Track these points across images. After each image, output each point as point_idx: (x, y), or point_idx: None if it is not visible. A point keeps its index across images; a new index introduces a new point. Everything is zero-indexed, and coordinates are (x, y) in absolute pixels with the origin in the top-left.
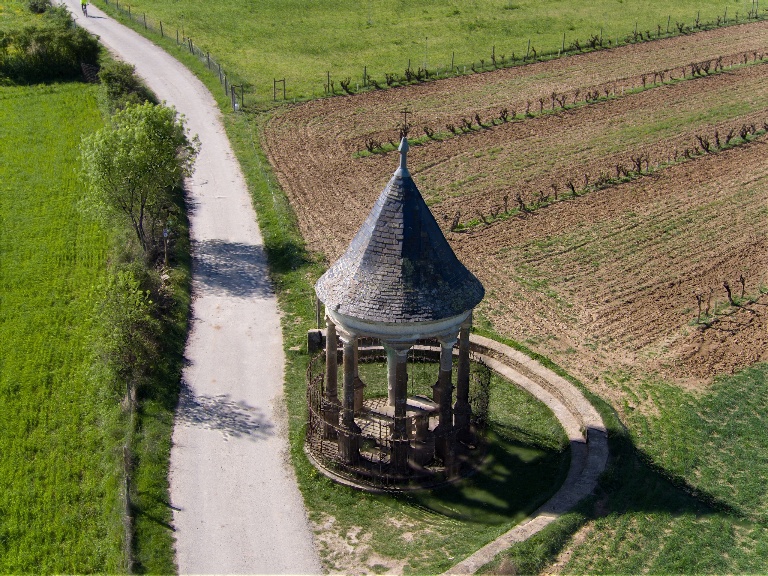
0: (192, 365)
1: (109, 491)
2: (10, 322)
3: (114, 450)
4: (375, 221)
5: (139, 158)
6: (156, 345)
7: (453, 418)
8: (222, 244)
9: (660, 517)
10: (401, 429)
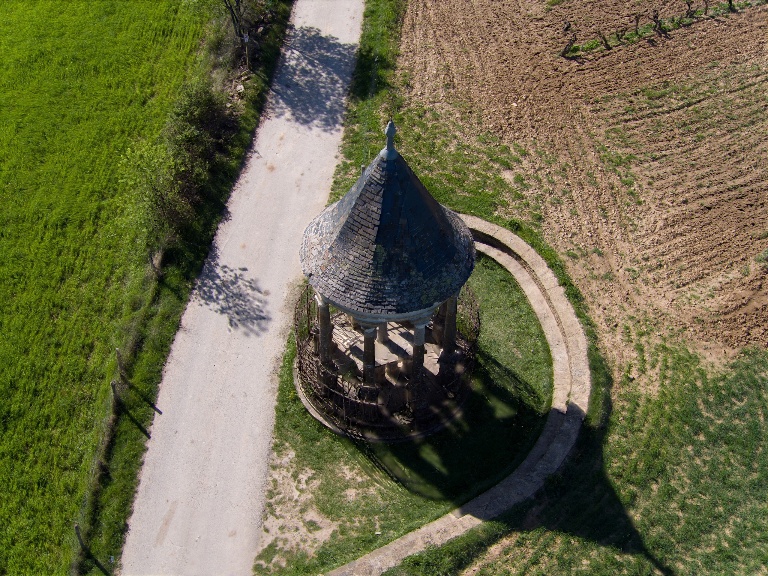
0: (230, 220)
1: (108, 376)
2: (84, 125)
3: (124, 327)
4: (356, 197)
5: None
6: (195, 199)
7: None
8: (317, 37)
9: (585, 543)
10: None
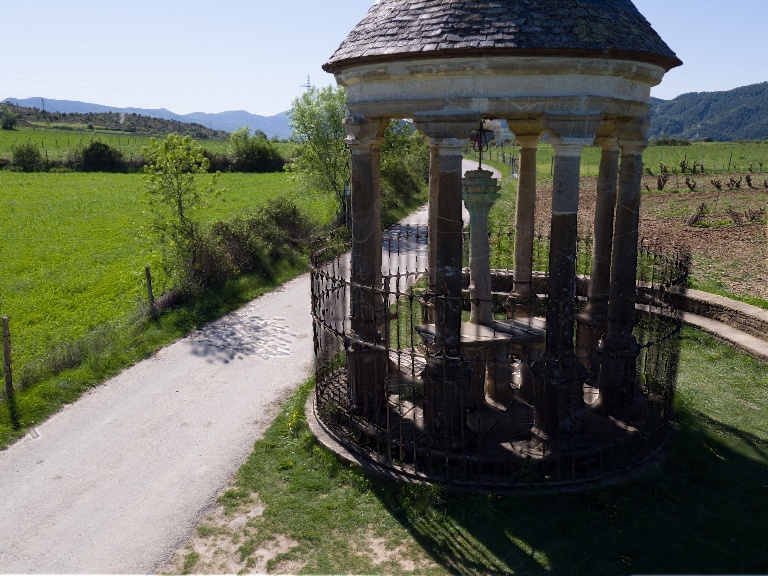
0: (282, 291)
1: None
2: None
3: None
4: None
5: (330, 111)
6: (241, 259)
7: None
8: (423, 226)
9: None
10: (445, 339)
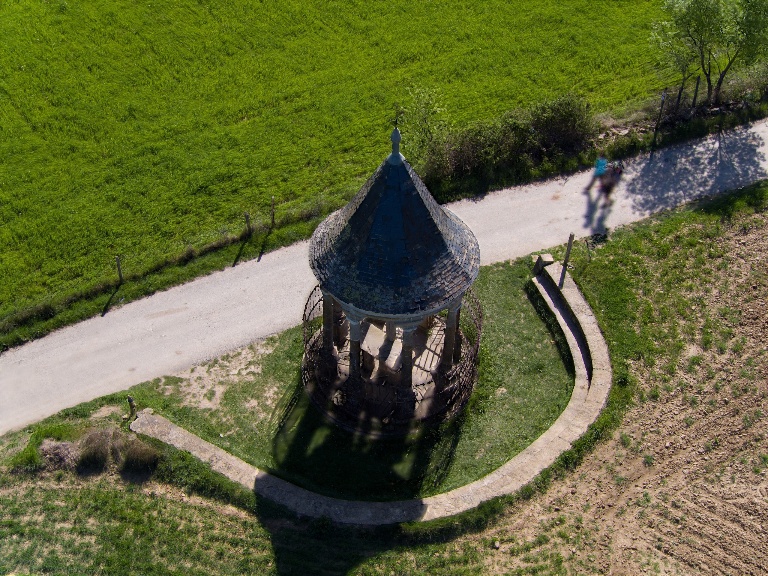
0: (475, 202)
1: None
2: (506, 79)
3: None
4: None
5: (682, 14)
6: None
7: None
8: (752, 147)
9: (272, 573)
10: None
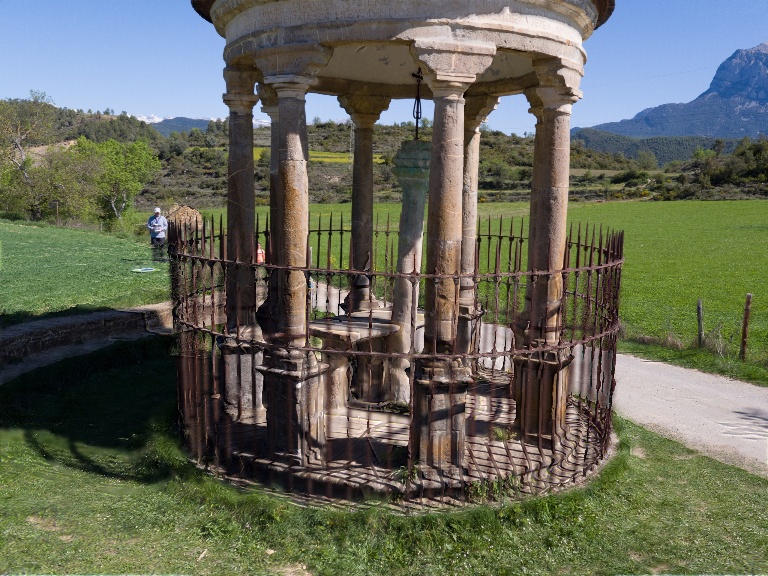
0: None
1: None
2: None
3: None
4: None
5: None
6: None
7: None
8: None
9: None
10: None
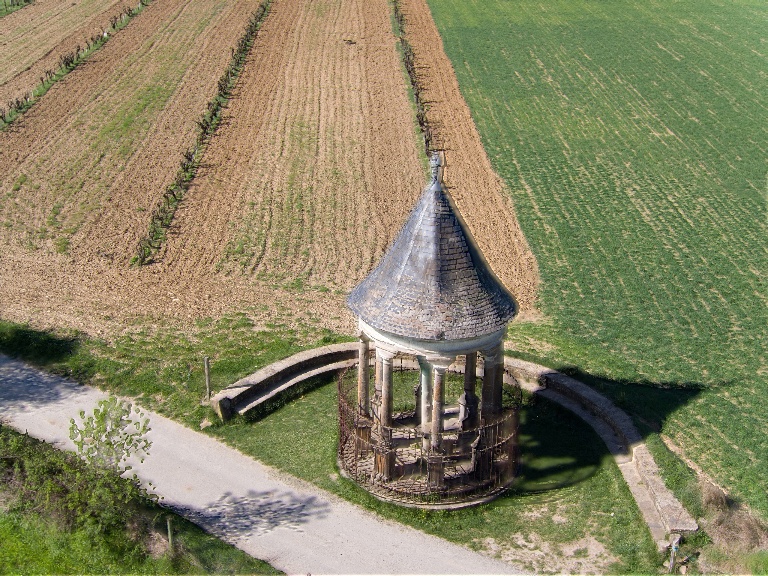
0: (140, 486)
1: None
2: None
3: None
4: (437, 241)
5: None
6: None
7: (461, 412)
8: None
9: (684, 410)
10: (490, 432)
